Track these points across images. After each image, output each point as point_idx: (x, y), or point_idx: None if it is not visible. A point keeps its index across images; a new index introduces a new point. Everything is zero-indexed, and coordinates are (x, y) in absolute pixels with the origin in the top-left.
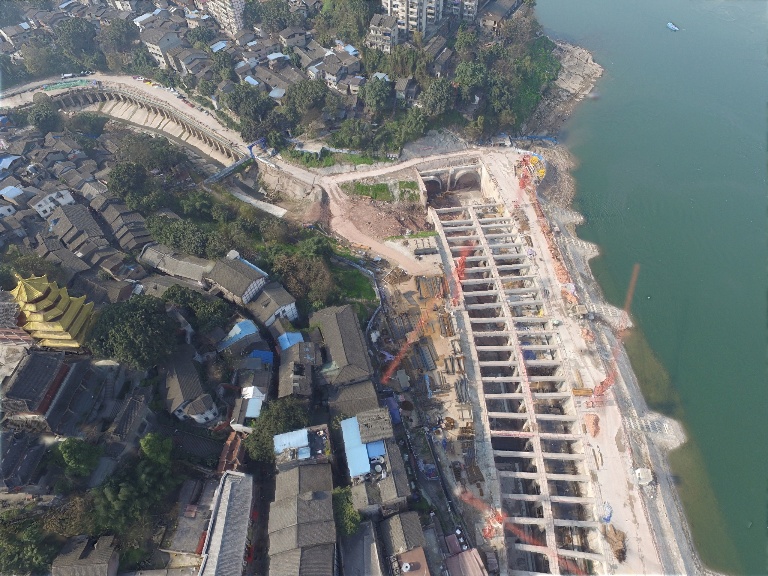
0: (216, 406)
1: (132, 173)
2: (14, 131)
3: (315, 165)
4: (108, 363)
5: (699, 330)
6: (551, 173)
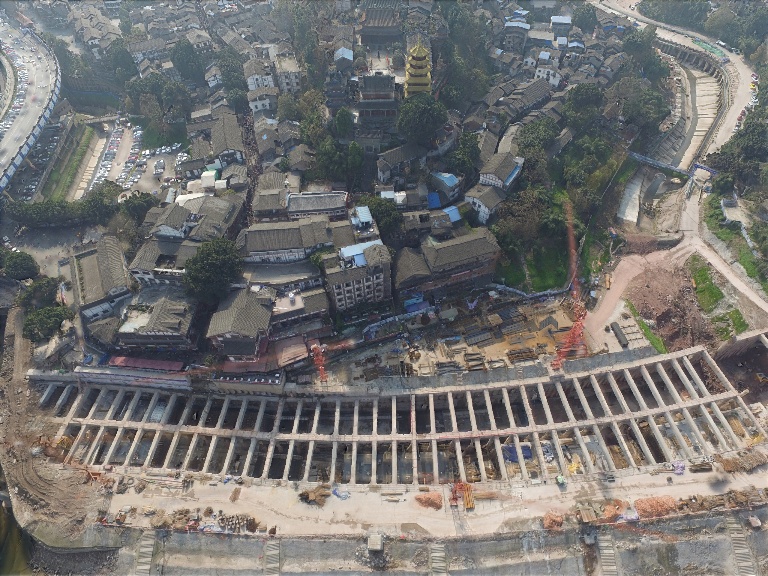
0: (388, 178)
1: (589, 93)
2: (614, 38)
3: (711, 225)
4: None
5: None
6: None
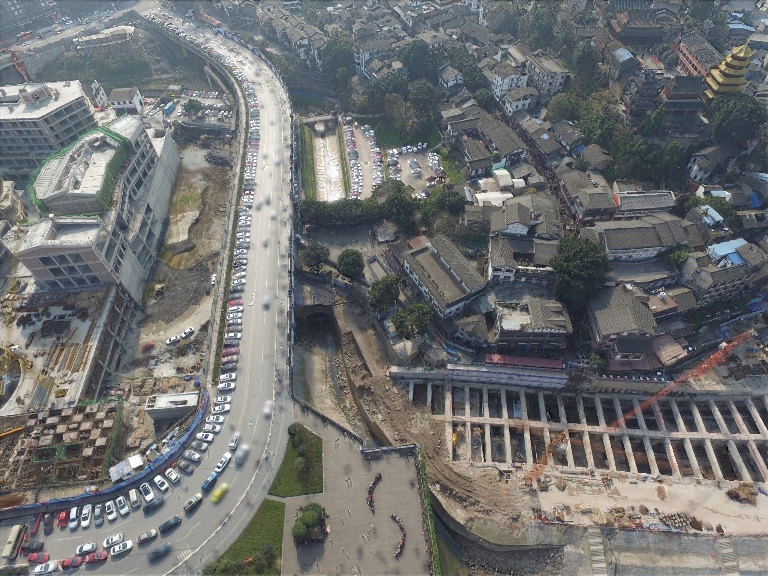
0: (707, 178)
1: None
2: None
3: None
4: (704, 120)
5: None
6: None
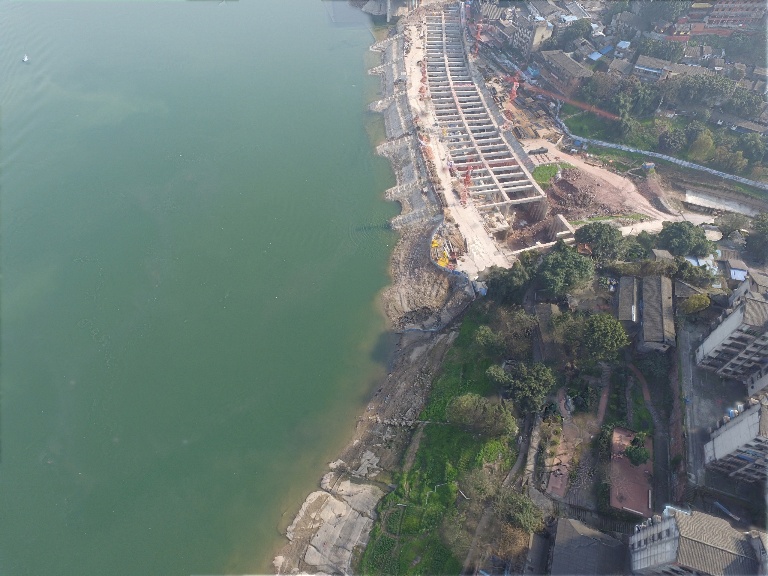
0: None
1: None
2: None
3: None
4: None
5: (331, 149)
6: (423, 251)
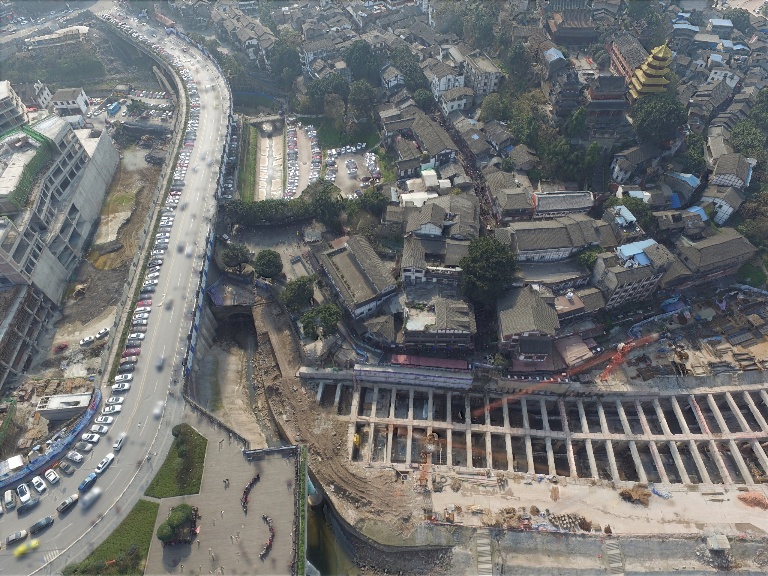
0: (628, 178)
1: None
2: None
3: None
4: (630, 120)
5: None
6: None
